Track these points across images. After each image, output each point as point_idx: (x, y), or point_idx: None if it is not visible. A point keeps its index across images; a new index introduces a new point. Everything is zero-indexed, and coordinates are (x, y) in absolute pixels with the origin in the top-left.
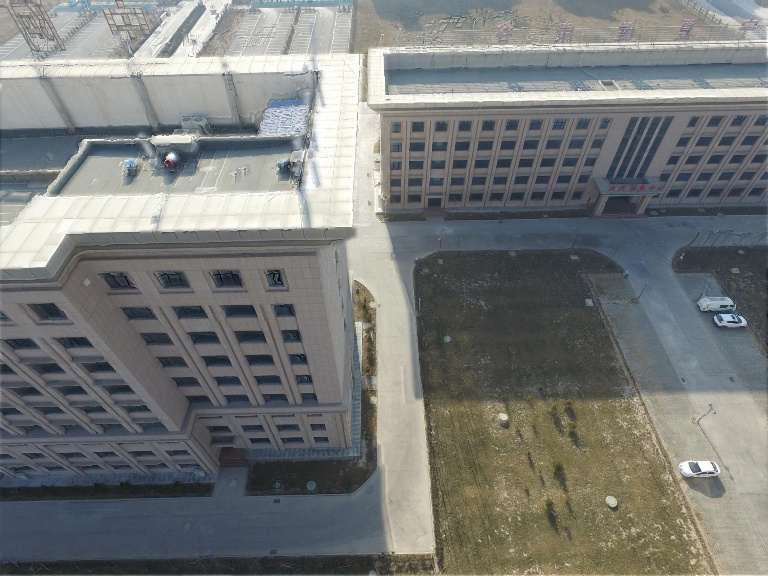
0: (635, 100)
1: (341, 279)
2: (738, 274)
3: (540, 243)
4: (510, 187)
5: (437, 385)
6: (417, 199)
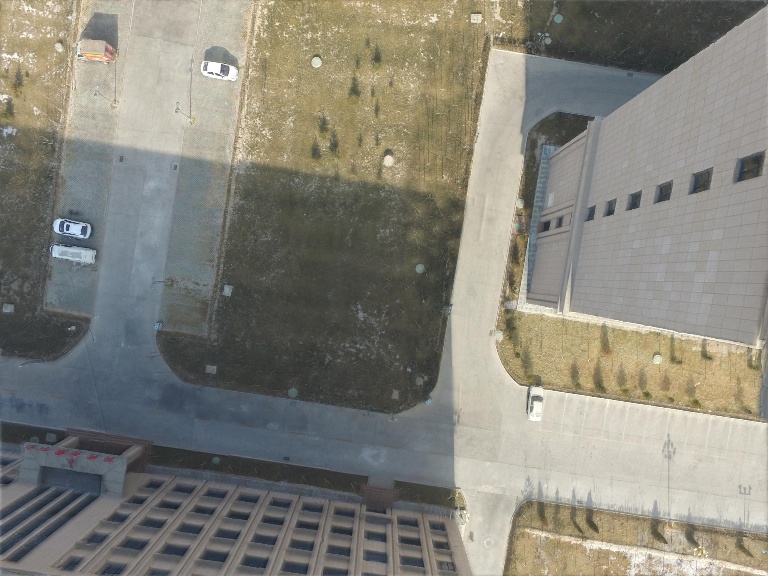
0: (1, 575)
1: (621, 228)
2: (8, 302)
3: (247, 405)
4: (258, 510)
5: (448, 210)
6: (402, 523)
